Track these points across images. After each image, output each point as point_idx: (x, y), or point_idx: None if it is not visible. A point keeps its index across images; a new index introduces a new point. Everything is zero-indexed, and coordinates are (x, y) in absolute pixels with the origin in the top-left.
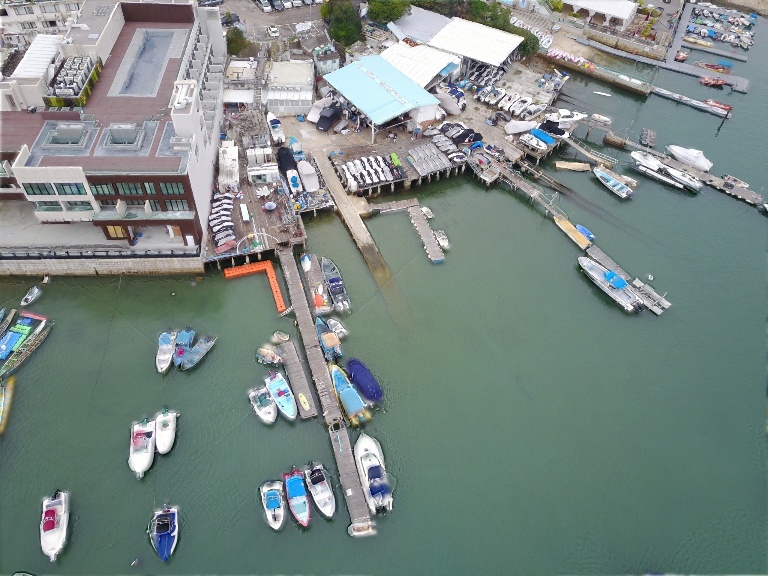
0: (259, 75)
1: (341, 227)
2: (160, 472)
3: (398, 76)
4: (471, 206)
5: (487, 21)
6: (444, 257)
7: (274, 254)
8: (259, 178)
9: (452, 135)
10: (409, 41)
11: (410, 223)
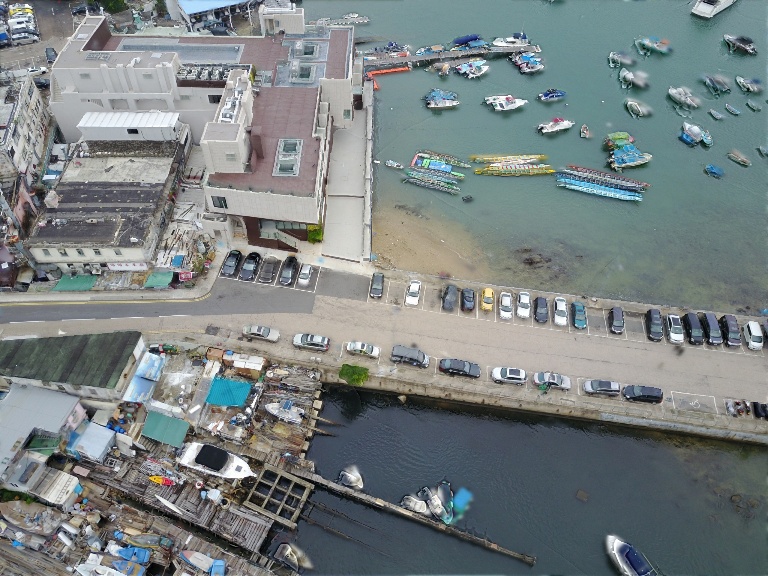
0: None
1: None
2: None
3: None
4: (317, 8)
5: None
6: (367, 17)
7: None
8: None
9: None
10: None
11: None
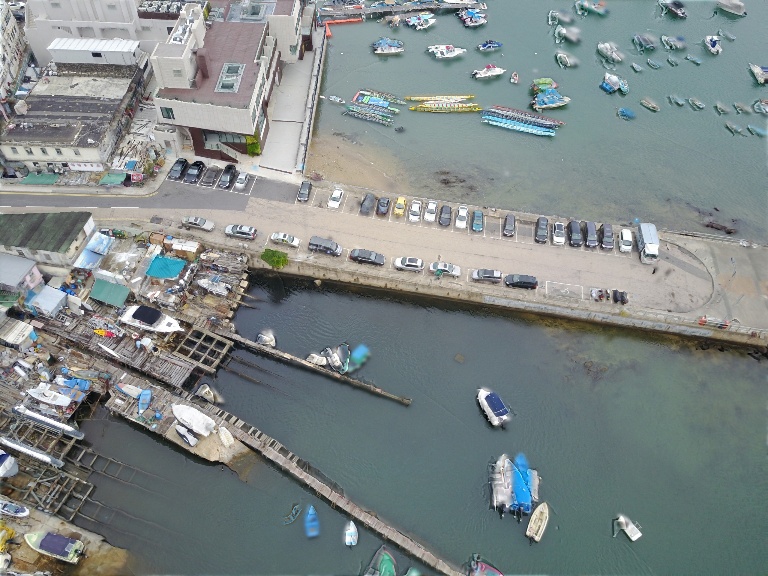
0: None
1: None
2: None
3: None
4: None
5: None
6: None
7: None
8: None
9: None
10: None
11: None
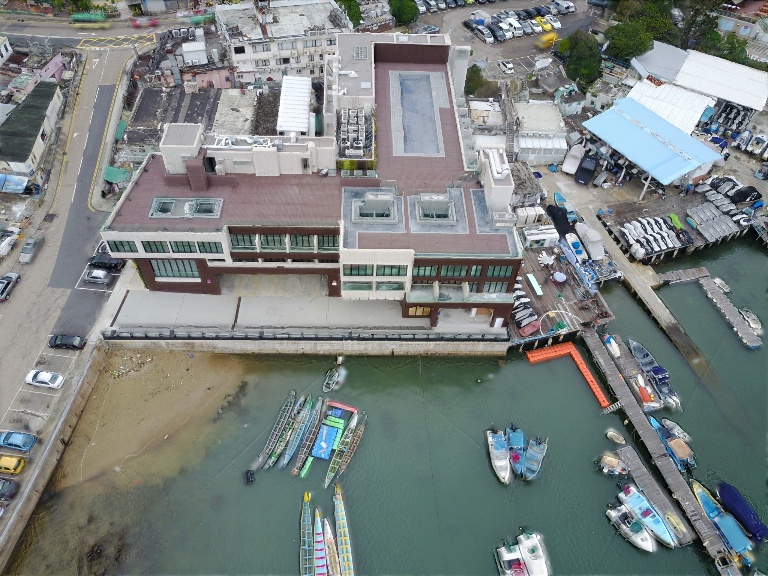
0: (511, 121)
1: (631, 300)
2: None
3: (664, 124)
4: (763, 276)
5: (724, 54)
6: (762, 342)
7: (575, 335)
8: (535, 242)
9: (726, 192)
10: (653, 79)
11: (706, 297)
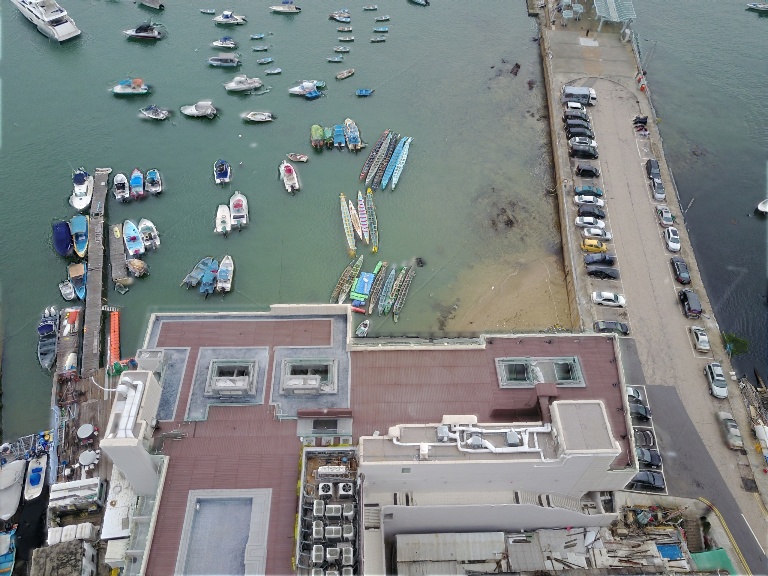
0: None
1: (7, 430)
2: (227, 199)
3: None
4: None
5: None
6: None
7: None
8: None
9: None
10: None
11: None
